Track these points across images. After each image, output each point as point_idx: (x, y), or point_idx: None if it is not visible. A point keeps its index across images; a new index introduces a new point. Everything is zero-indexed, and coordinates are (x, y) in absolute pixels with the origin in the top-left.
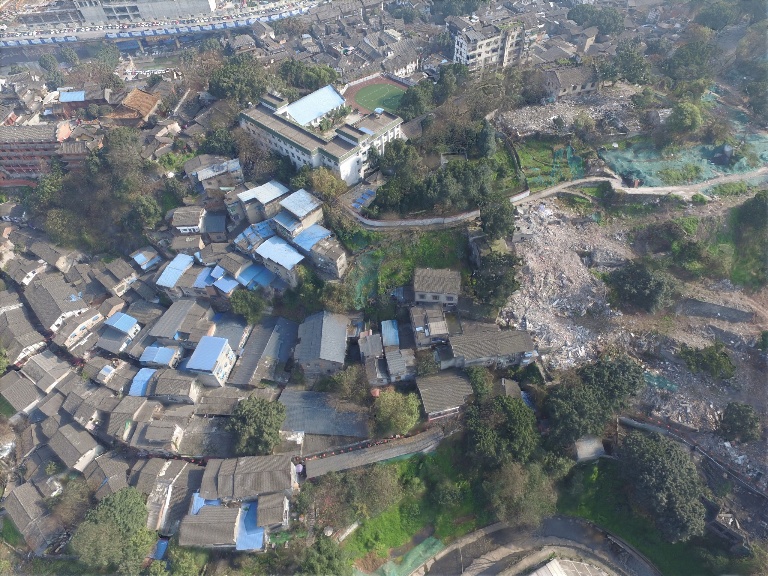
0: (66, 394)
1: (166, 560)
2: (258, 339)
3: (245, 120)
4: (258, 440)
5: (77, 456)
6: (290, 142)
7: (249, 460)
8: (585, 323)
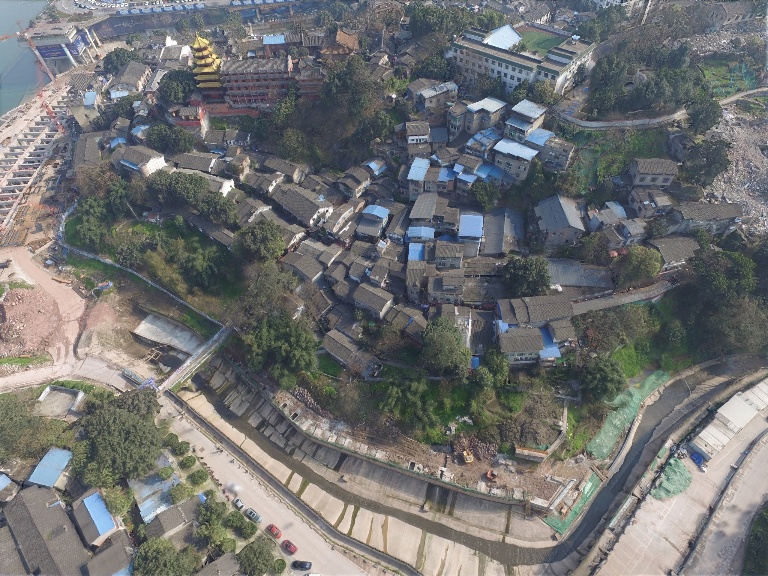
0: (348, 265)
1: (486, 367)
2: (493, 223)
3: (455, 49)
4: (536, 284)
5: (384, 302)
6: (509, 62)
7: (532, 298)
8: None
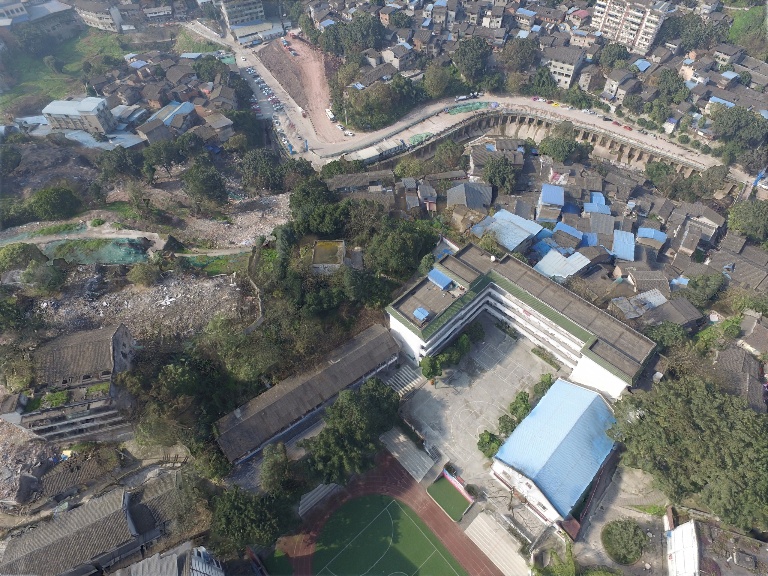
0: (655, 205)
1: None
2: None
3: None
4: None
5: (611, 172)
6: None
7: None
8: (259, 206)
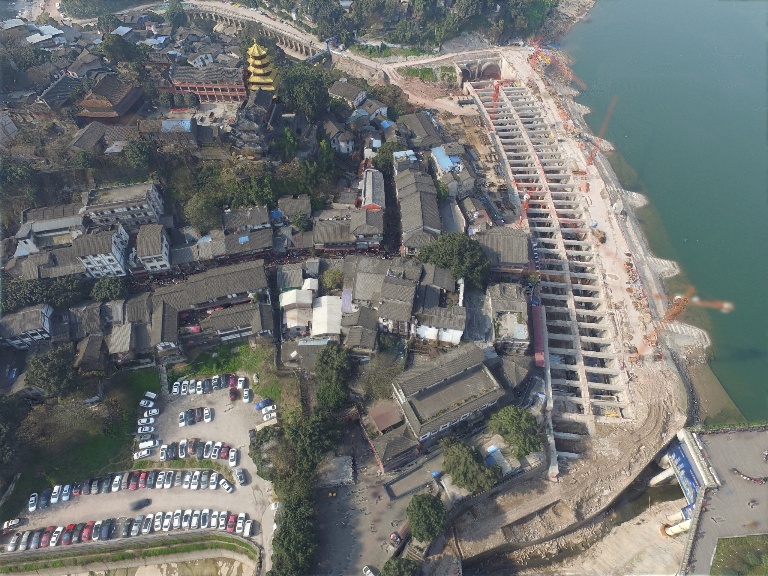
0: None
1: None
2: None
3: None
4: None
5: None
6: None
7: None
8: None
